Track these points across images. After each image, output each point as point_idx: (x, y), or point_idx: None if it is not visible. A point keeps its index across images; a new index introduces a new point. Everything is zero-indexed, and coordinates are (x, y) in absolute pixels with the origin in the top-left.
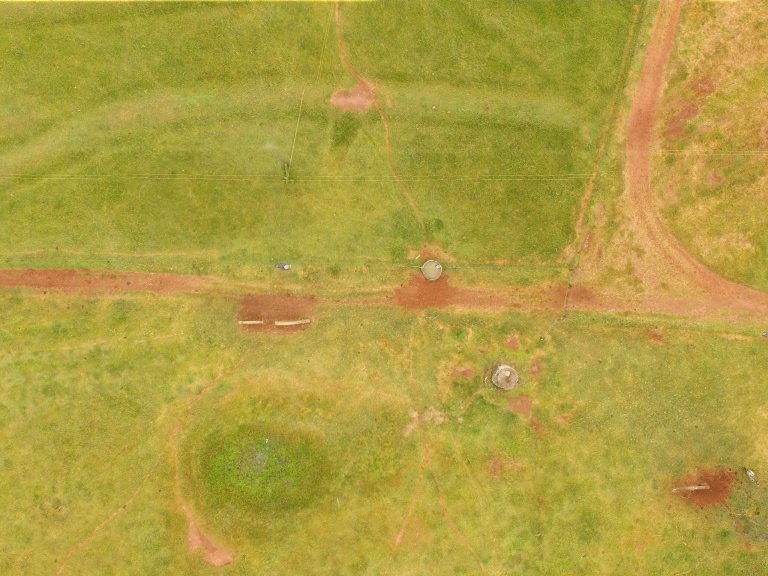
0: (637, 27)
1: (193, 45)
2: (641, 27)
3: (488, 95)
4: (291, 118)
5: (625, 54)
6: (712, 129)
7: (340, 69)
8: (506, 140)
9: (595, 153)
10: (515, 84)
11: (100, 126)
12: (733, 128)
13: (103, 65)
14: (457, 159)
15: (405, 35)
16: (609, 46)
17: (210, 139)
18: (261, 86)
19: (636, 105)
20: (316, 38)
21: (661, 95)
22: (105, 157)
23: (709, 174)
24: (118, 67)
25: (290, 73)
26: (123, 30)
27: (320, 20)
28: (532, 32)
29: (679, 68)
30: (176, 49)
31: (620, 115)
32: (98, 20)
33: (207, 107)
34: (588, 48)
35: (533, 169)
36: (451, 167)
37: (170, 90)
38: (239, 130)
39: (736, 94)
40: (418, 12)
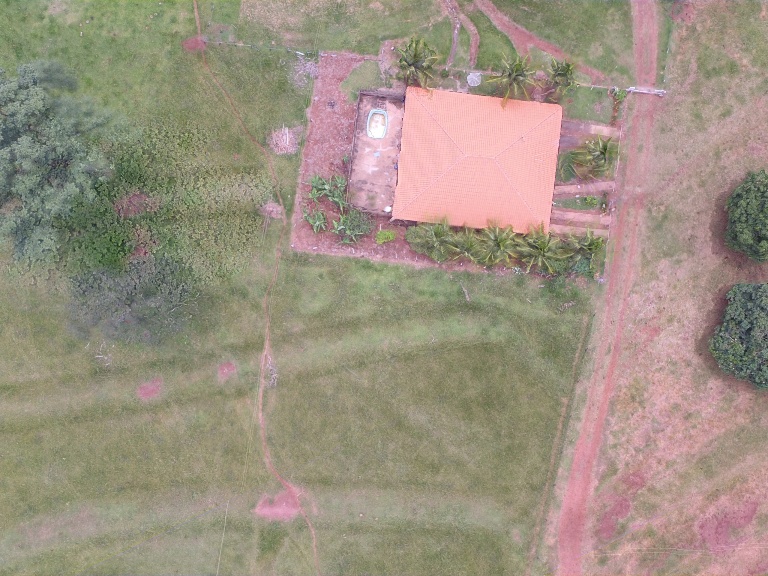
0: (565, 422)
1: (115, 454)
2: (570, 421)
3: (416, 498)
4: (216, 529)
5: (554, 449)
6: (644, 527)
7: (265, 474)
8: (436, 545)
9: (526, 556)
10: (443, 484)
11: (21, 546)
12: (666, 524)
13: (23, 478)
14: (386, 566)
15: (330, 436)
16: (538, 442)
17: (134, 554)
18: (185, 496)
19: (567, 504)
20: (240, 442)
21: (592, 493)
22: (28, 575)
23: (643, 574)
24: (39, 480)
25: (214, 480)
26: (43, 440)
27: (243, 423)
28: (459, 430)
29: (609, 464)
30: (97, 459)
31: (550, 516)
32: (18, 430)
33: (130, 521)
34: (516, 445)
35: (464, 574)
36: (381, 574)
37: (92, 502)
38: (163, 544)
39: (668, 489)
40: (343, 412)
